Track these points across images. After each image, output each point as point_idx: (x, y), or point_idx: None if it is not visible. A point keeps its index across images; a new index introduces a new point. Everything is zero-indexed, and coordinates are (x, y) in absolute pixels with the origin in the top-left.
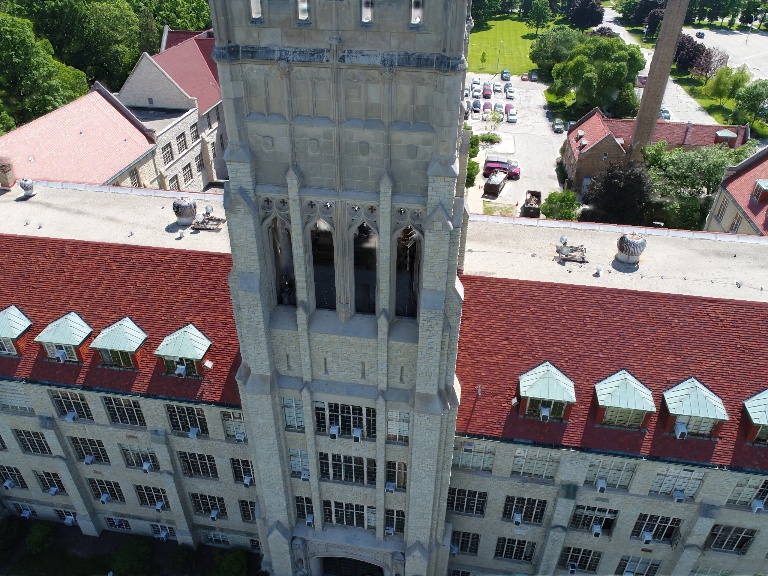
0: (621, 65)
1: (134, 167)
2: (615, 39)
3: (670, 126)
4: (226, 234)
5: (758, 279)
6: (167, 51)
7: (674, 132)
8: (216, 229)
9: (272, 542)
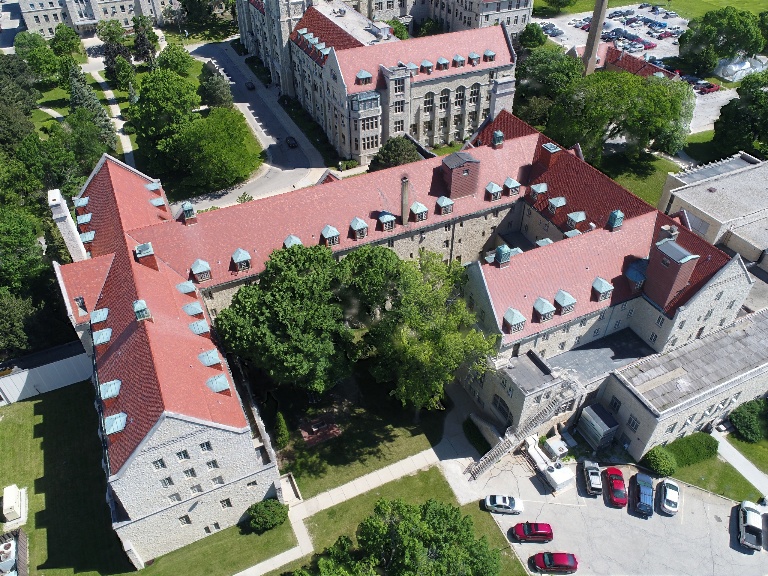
0: (710, 28)
1: None
2: (742, 12)
3: (637, 61)
4: None
5: (351, 25)
6: None
7: (636, 65)
8: None
9: (269, 61)
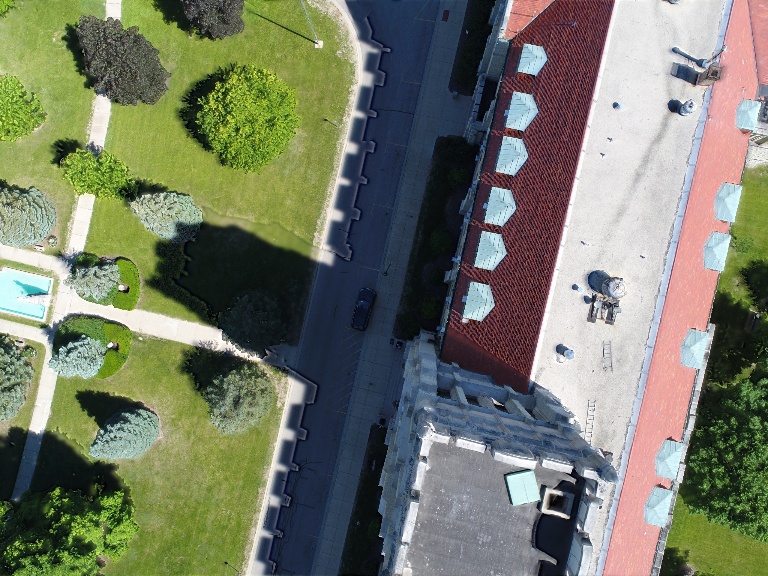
0: None
1: None
2: None
3: None
4: (583, 328)
5: None
6: None
7: None
8: (593, 318)
9: None
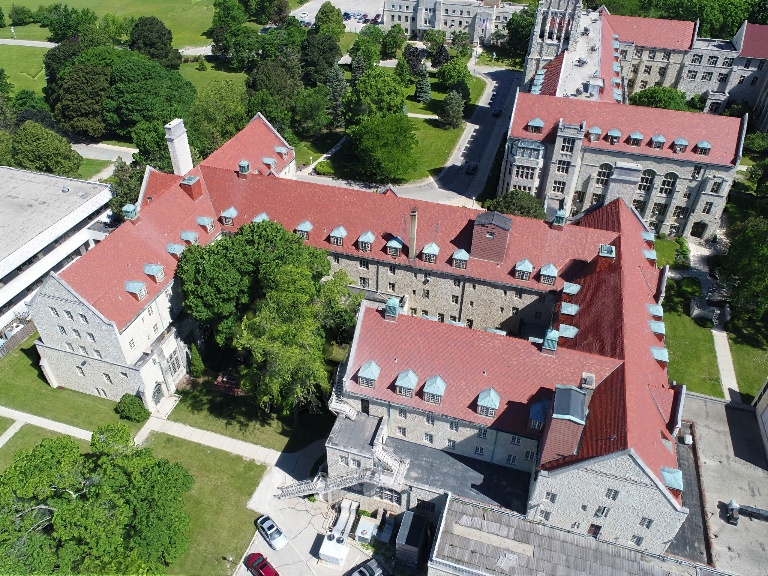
0: None
1: (670, 51)
2: None
3: None
4: (581, 36)
5: None
6: (767, 26)
7: None
8: (583, 35)
9: None
